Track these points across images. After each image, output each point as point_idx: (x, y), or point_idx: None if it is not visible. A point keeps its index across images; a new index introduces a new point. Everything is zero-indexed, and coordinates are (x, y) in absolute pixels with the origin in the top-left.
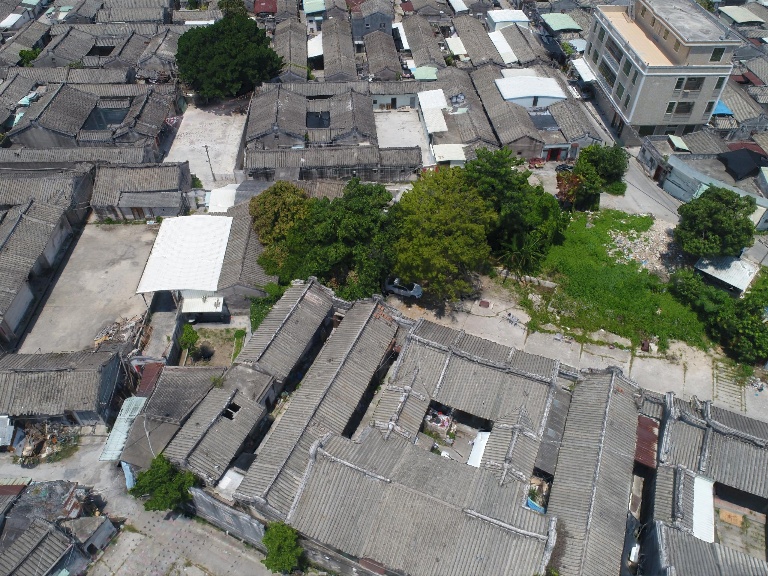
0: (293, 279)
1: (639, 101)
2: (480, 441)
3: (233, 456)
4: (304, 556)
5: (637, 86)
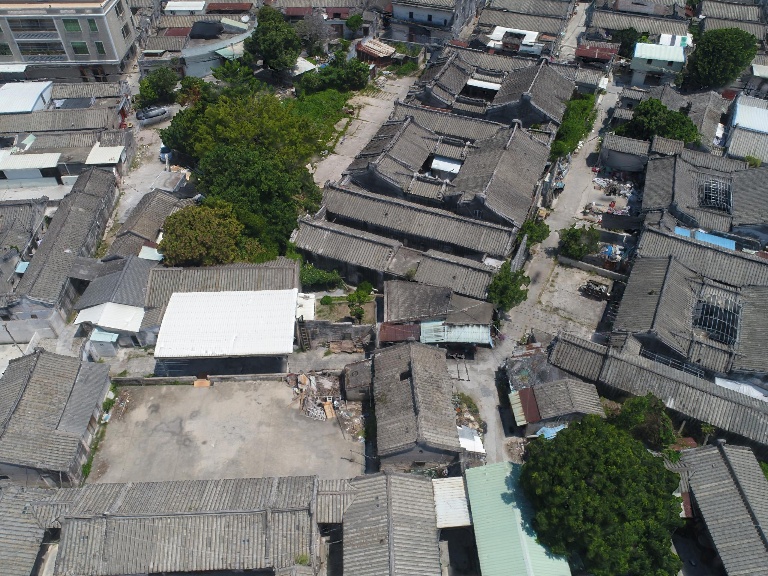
0: (277, 250)
1: (113, 39)
2: (439, 165)
3: None
4: None
5: (103, 29)
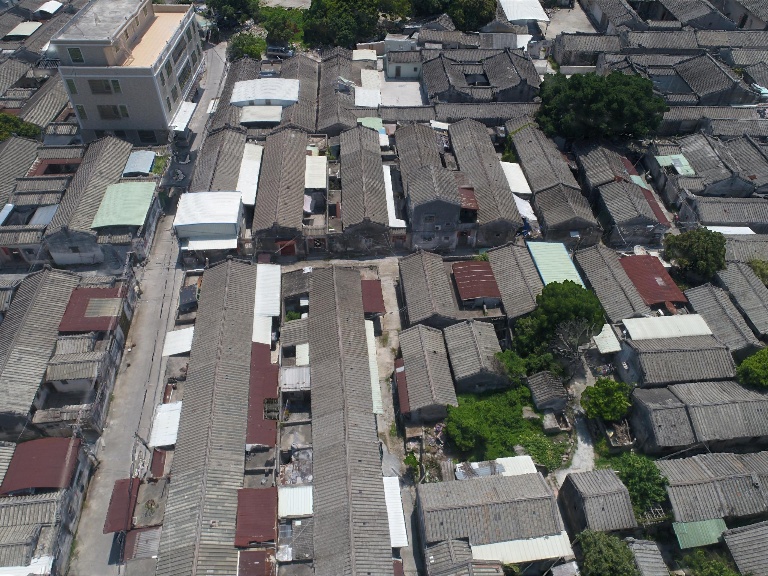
0: None
1: None
2: None
3: None
4: None
5: None
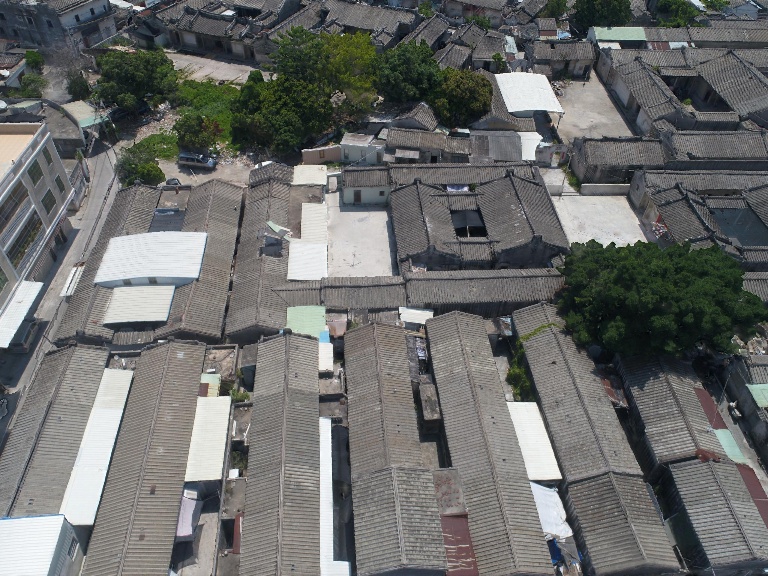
0: None
1: None
2: None
3: None
4: None
5: None
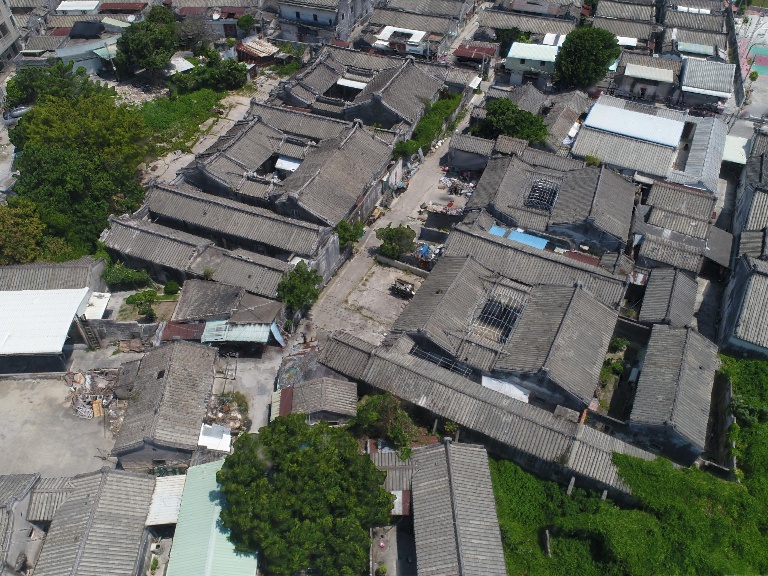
0: (88, 250)
1: None
2: (283, 164)
3: None
4: None
5: None
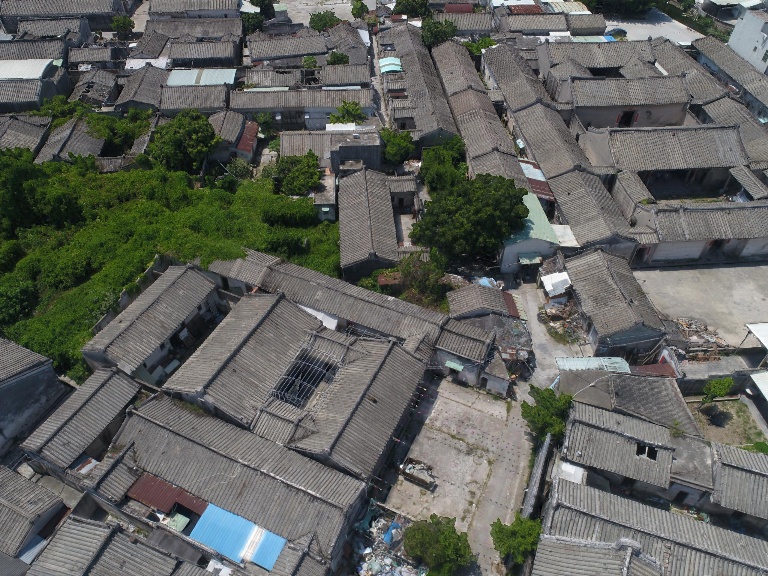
0: None
1: None
2: None
3: (598, 467)
4: (521, 573)
5: None
